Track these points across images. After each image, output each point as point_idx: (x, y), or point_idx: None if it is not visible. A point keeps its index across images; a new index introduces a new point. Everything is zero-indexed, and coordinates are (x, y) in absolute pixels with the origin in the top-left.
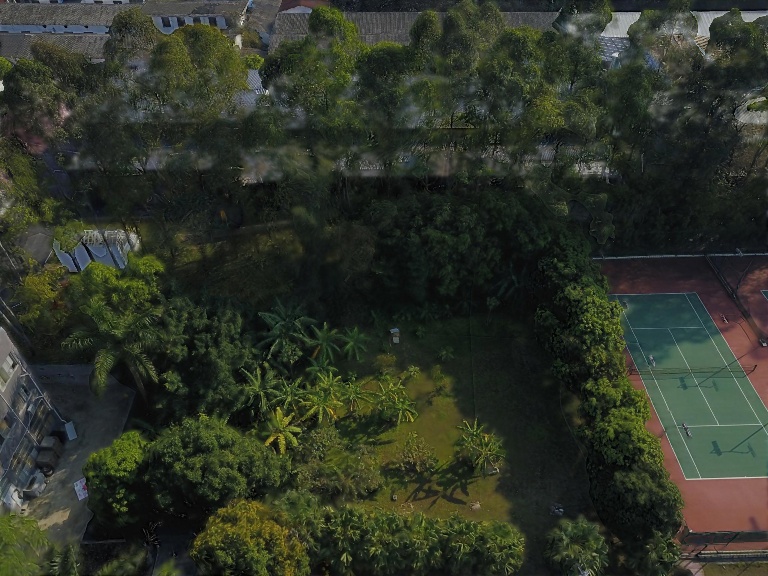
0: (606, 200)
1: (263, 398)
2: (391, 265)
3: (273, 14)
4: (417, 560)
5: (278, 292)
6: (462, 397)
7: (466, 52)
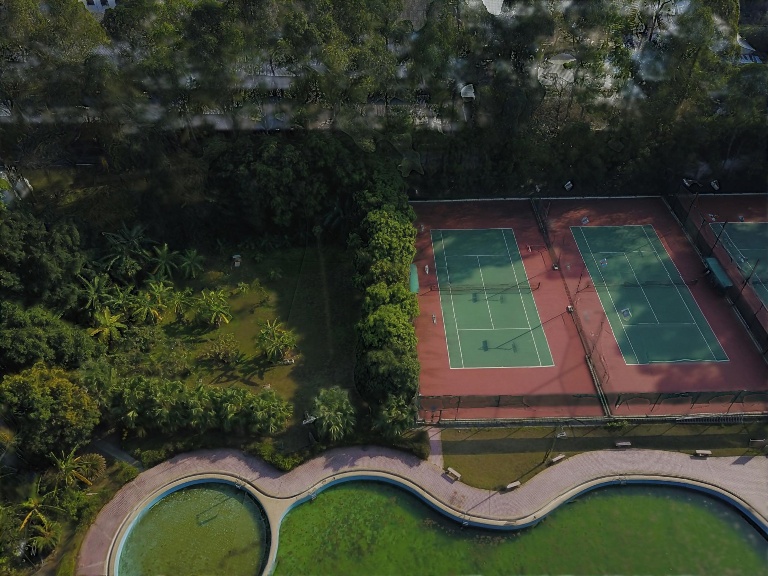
0: (409, 139)
1: (95, 299)
2: (226, 196)
3: None
4: (195, 419)
5: (124, 217)
6: (281, 307)
7: (263, 4)
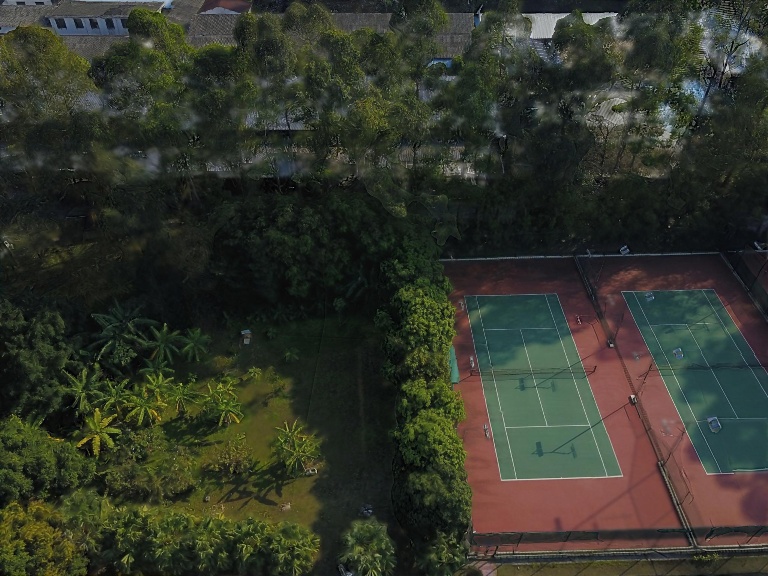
0: (445, 201)
1: (83, 399)
2: (234, 266)
3: (191, 15)
4: (203, 561)
5: (116, 293)
6: (299, 398)
7: (279, 54)
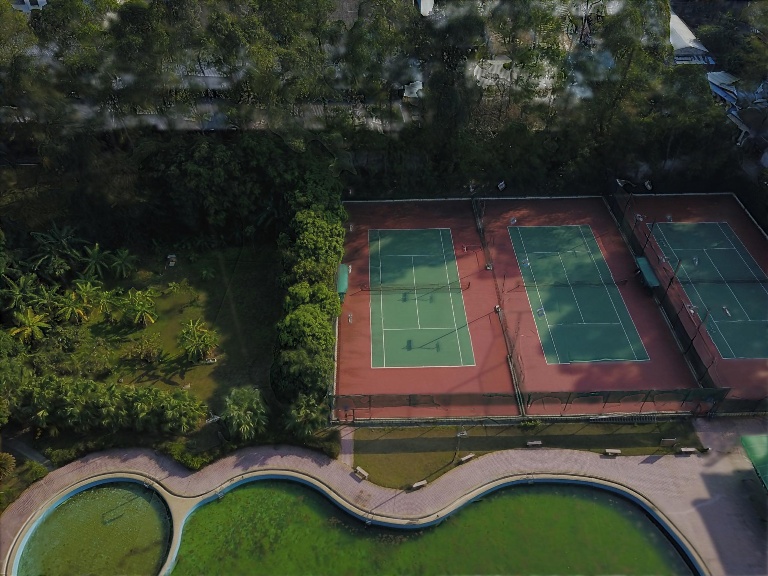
0: (339, 139)
1: (19, 299)
2: (158, 196)
3: None
4: (107, 418)
5: (54, 217)
6: (210, 307)
7: (185, 5)
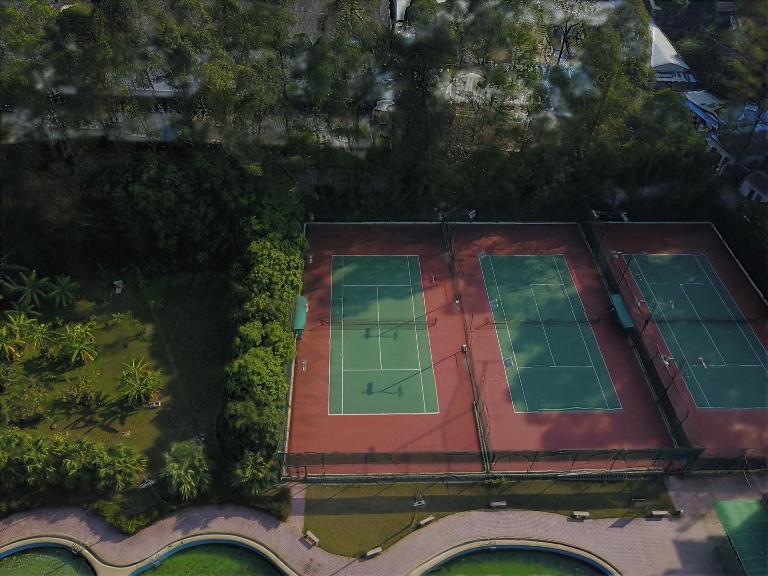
0: (300, 162)
1: None
2: (102, 218)
3: None
4: (33, 475)
5: None
6: (157, 342)
7: (129, 16)
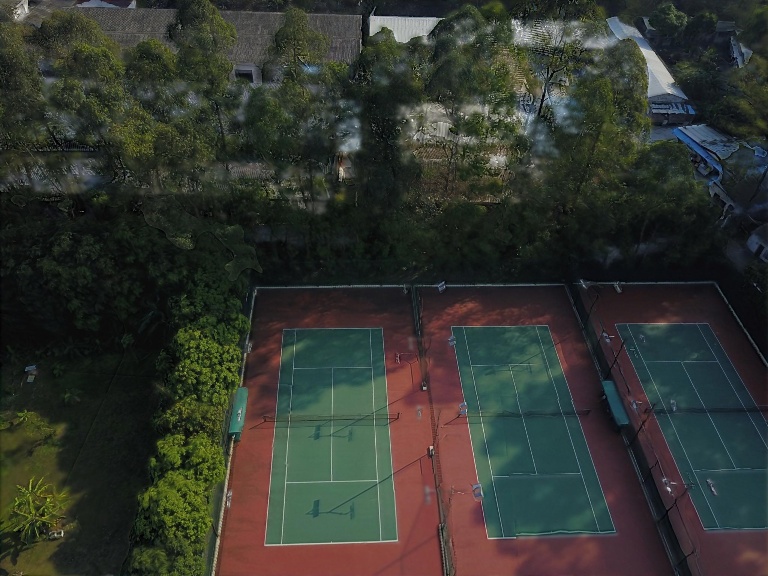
0: (237, 233)
1: None
2: (6, 299)
3: None
4: None
5: None
6: (69, 446)
7: (18, 70)
